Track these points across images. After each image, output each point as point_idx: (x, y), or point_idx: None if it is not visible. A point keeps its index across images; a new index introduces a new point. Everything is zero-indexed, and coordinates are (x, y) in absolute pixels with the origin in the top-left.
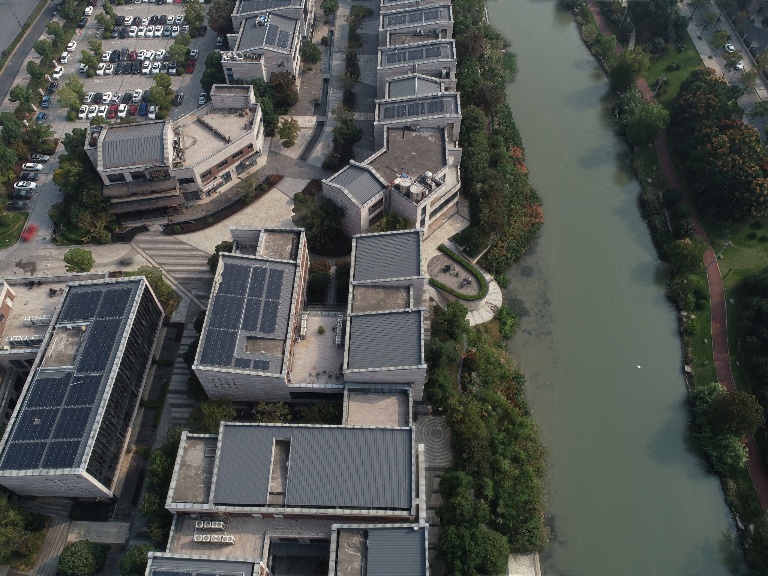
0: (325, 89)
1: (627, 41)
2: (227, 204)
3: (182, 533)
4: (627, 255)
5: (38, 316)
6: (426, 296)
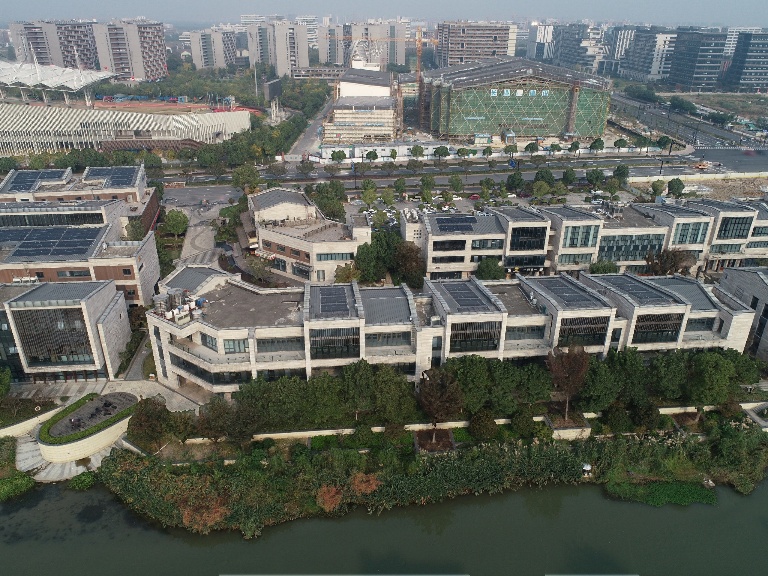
0: None
1: None
2: None
3: None
4: None
5: None
6: (72, 393)
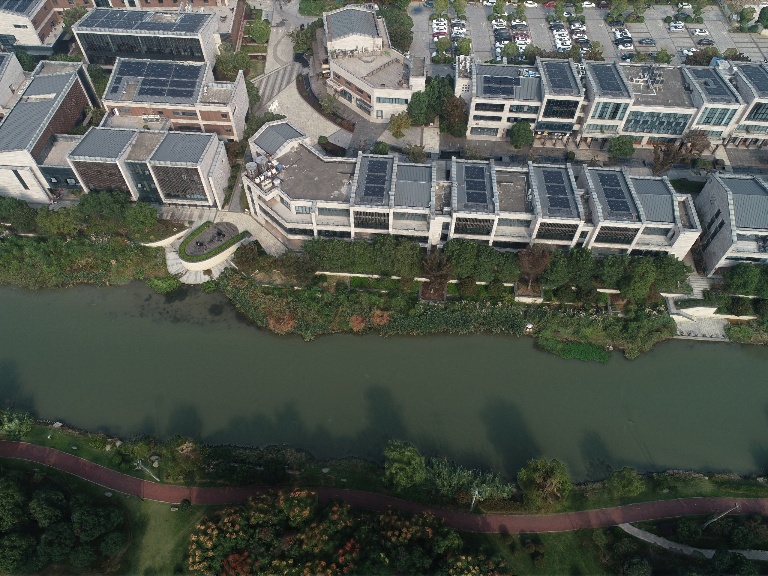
0: (487, 160)
1: (659, 530)
2: None
3: None
4: (217, 413)
5: None
6: (195, 219)
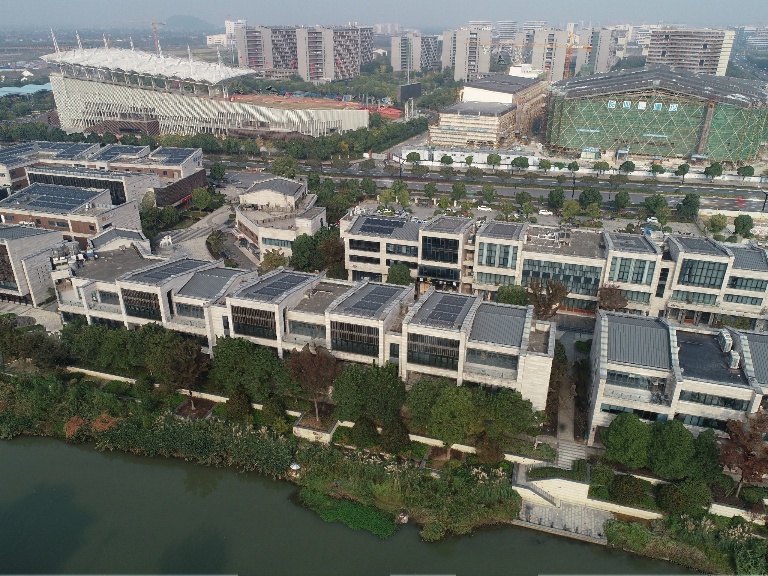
0: None
1: None
2: None
3: None
4: None
5: None
6: (4, 311)
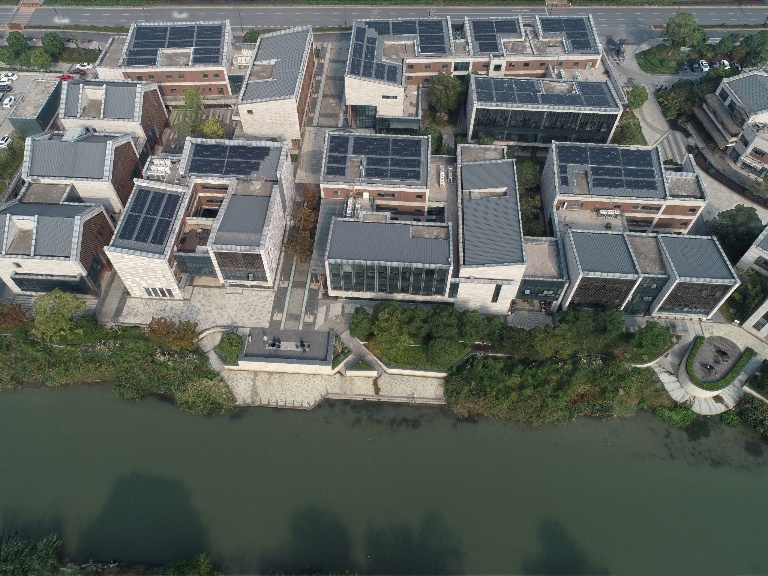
0: None
1: None
2: (737, 182)
3: (446, 165)
4: None
5: (581, 78)
6: (681, 332)
